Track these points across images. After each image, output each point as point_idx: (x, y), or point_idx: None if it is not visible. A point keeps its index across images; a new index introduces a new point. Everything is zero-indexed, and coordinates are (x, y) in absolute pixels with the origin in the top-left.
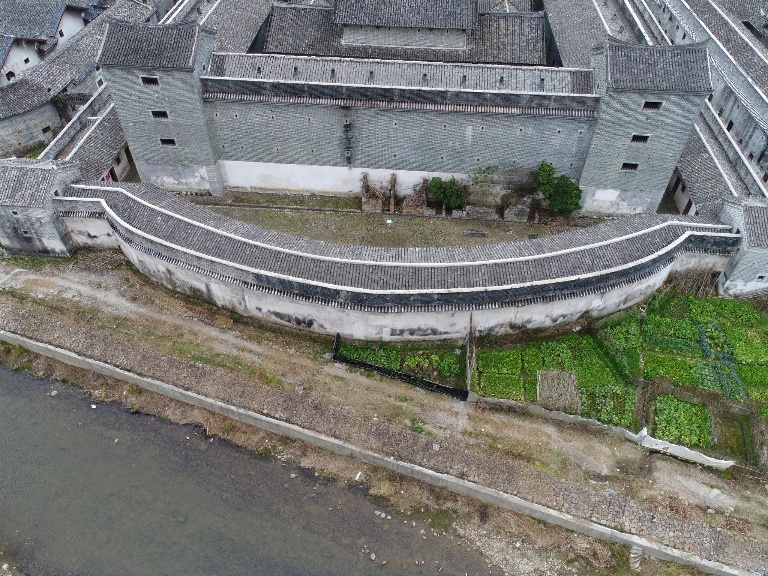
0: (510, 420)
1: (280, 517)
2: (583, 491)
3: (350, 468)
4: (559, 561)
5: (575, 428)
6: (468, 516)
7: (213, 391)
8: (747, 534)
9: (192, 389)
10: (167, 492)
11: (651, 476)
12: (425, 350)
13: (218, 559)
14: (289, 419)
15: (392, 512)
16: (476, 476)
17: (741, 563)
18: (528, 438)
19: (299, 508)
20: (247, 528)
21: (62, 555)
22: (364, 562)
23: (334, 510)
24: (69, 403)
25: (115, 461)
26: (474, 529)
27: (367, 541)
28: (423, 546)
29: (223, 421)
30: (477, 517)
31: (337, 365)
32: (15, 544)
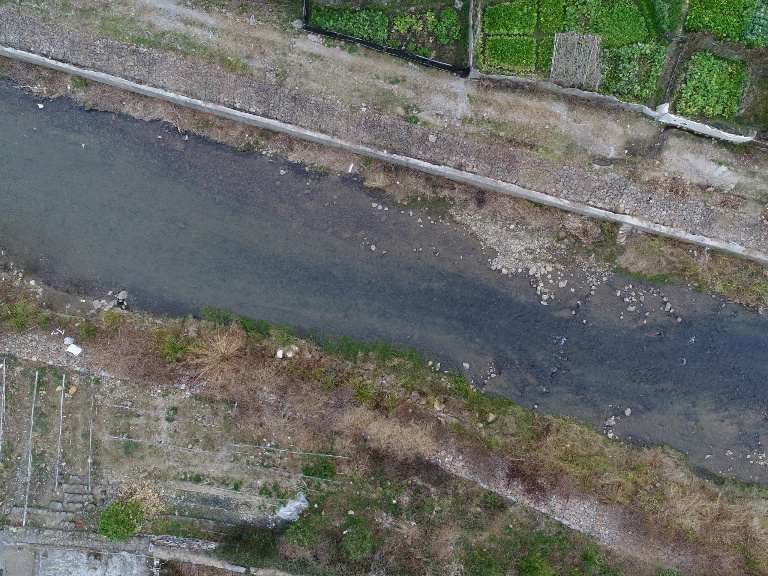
0: (516, 99)
1: (278, 216)
2: (585, 177)
3: (341, 160)
4: (550, 239)
5: (588, 105)
6: (465, 203)
7: (171, 83)
8: (739, 210)
9: (146, 82)
10: (158, 199)
11: (659, 156)
12: (418, 5)
13: (227, 260)
14: (266, 114)
15: (389, 203)
16: (475, 166)
17: (723, 235)
18: (534, 121)
19: (295, 206)
20: (248, 229)
21: (80, 267)
22: (365, 253)
23: (330, 205)
24: (11, 103)
25: (91, 169)
26: (470, 214)
27: (366, 233)
28: (420, 234)
29: (193, 115)
30: (474, 204)
31: (311, 37)
32: (31, 261)
